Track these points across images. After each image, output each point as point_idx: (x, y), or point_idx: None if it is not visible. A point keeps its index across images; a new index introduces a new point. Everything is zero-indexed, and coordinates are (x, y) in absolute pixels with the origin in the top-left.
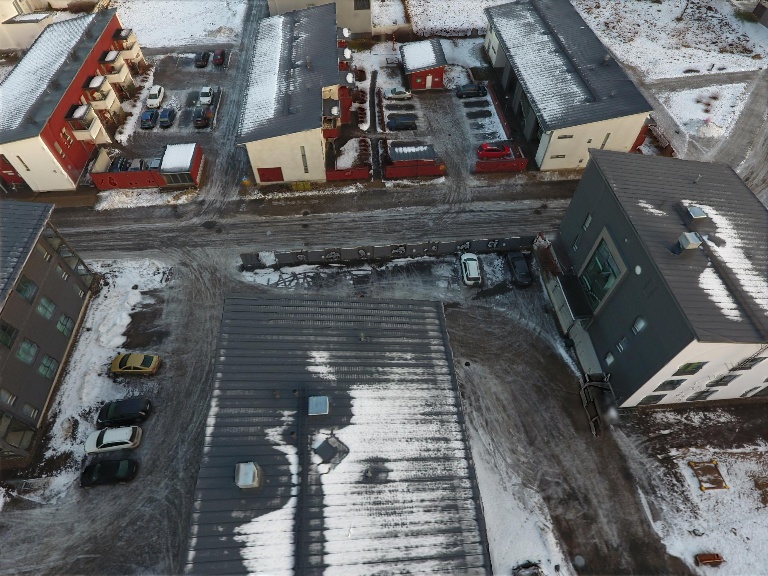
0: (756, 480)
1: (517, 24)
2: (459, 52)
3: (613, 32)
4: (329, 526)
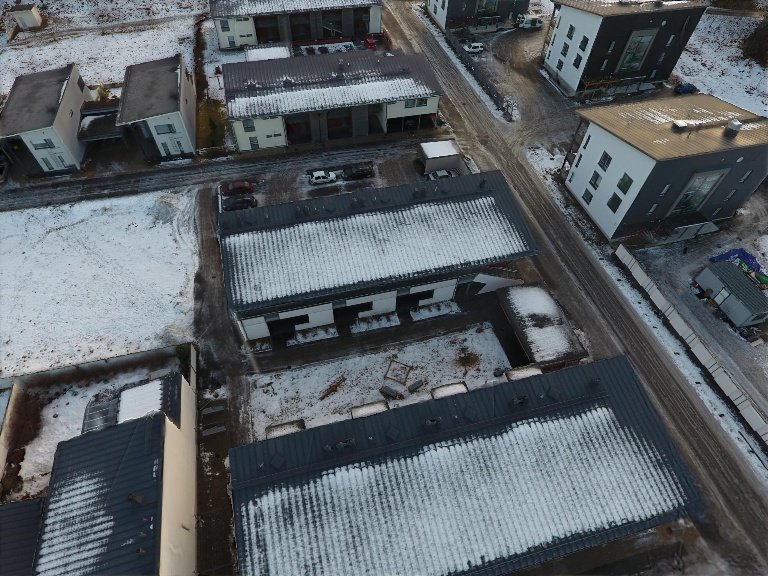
0: (534, 5)
1: (250, 5)
2: (230, 59)
3: (197, 7)
4: (653, 0)
